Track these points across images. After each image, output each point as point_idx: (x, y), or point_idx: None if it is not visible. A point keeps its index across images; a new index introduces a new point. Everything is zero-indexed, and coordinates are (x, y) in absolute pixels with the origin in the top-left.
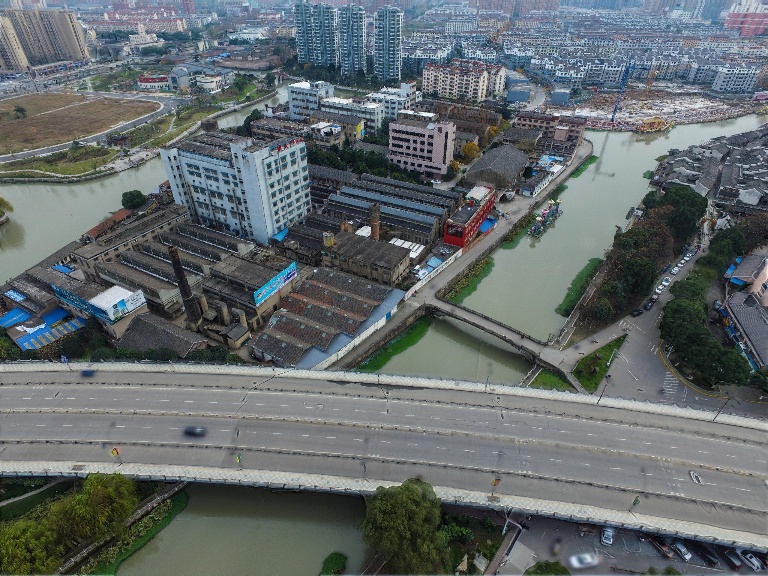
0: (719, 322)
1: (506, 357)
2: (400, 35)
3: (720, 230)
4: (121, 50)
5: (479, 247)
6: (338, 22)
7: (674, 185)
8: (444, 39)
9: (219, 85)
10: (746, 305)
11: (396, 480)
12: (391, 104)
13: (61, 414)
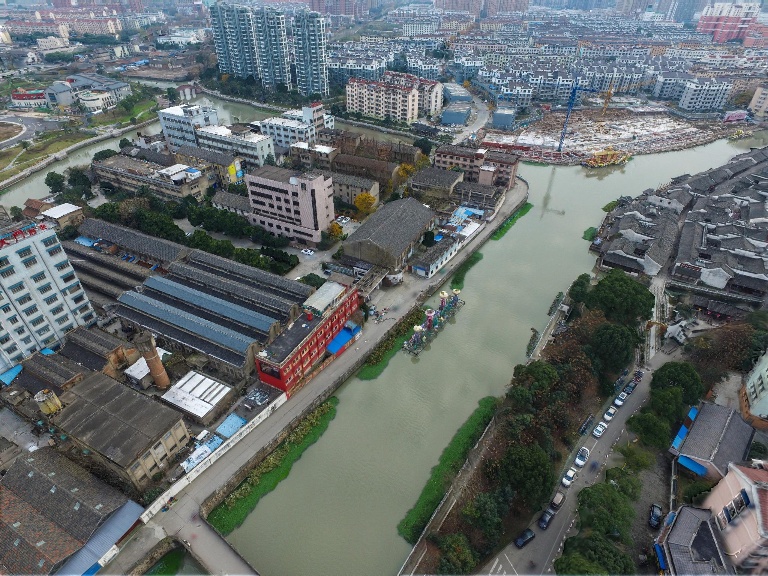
0: (653, 568)
1: None
2: (323, 44)
3: (672, 339)
4: (19, 57)
5: (320, 381)
6: (254, 28)
7: (617, 258)
8: (388, 45)
9: (107, 103)
10: (696, 552)
11: None
12: (290, 132)
13: None
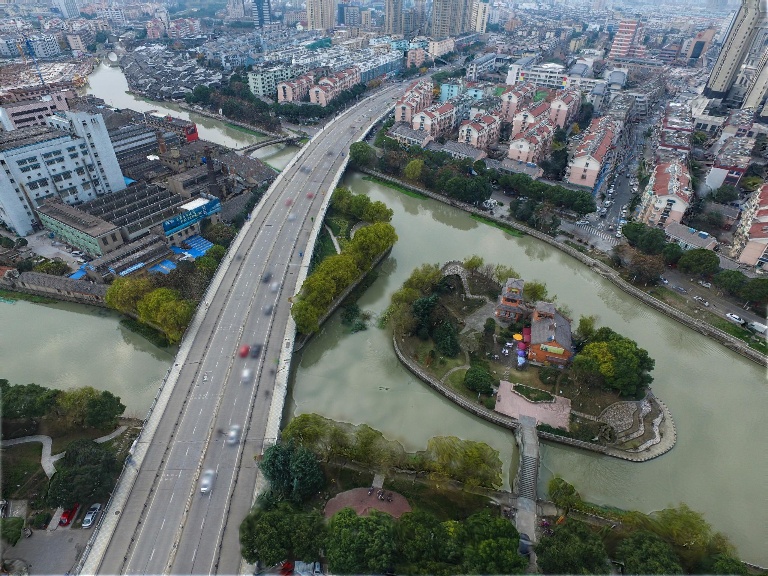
0: None
1: (281, 153)
2: None
3: None
4: None
5: None
6: None
7: (177, 94)
8: None
9: None
10: None
11: (344, 158)
12: None
13: (287, 220)
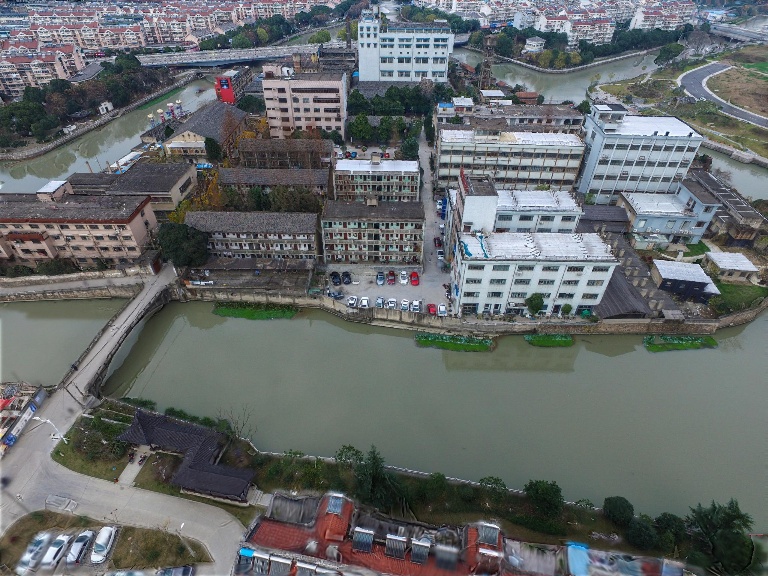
0: None
1: None
2: None
3: None
4: None
5: None
6: None
7: None
8: None
9: None
10: None
11: (247, 50)
12: None
13: None
